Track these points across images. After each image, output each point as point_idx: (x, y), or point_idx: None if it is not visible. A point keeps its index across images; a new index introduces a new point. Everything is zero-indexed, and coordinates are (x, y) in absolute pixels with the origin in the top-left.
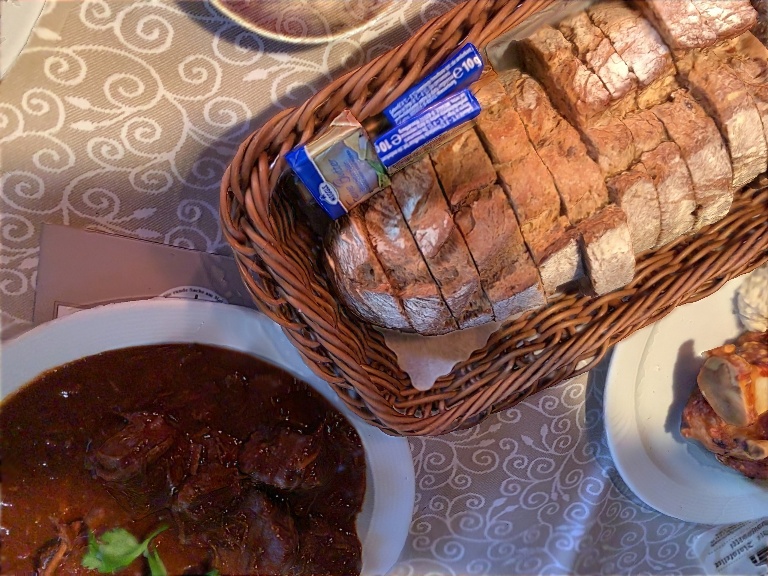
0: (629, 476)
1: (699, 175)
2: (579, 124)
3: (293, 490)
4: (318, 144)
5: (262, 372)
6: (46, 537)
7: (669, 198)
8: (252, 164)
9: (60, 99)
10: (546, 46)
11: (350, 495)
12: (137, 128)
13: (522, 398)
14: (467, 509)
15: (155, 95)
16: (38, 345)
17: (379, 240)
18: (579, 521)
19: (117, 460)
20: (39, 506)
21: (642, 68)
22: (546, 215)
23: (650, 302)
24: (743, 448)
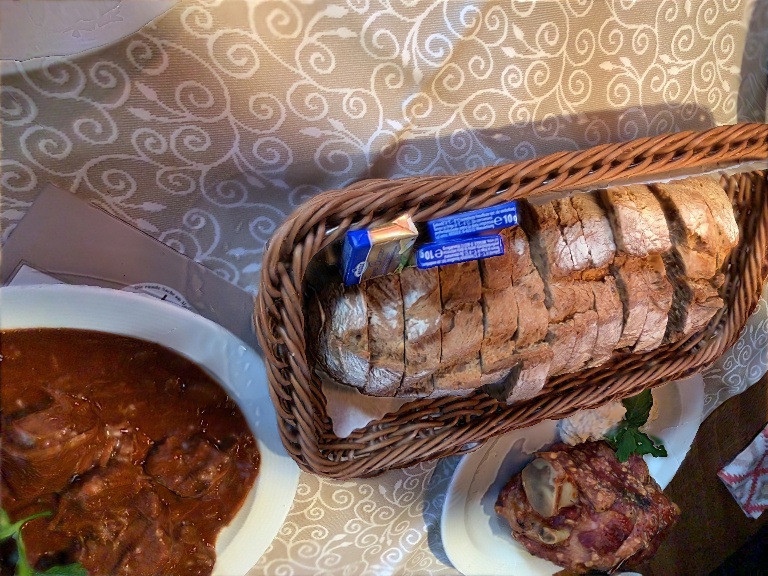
0: (447, 535)
1: (601, 339)
2: (547, 279)
3: (178, 496)
4: (380, 234)
5: (202, 384)
6: None
7: (579, 349)
8: (312, 225)
9: (130, 81)
10: (542, 211)
11: (226, 510)
12: (190, 135)
13: (415, 463)
14: (310, 538)
15: (220, 113)
16: (2, 304)
17: (375, 314)
18: (391, 564)
19: (38, 439)
20: None
21: (597, 254)
22: (502, 336)
23: (529, 413)
24: (539, 532)
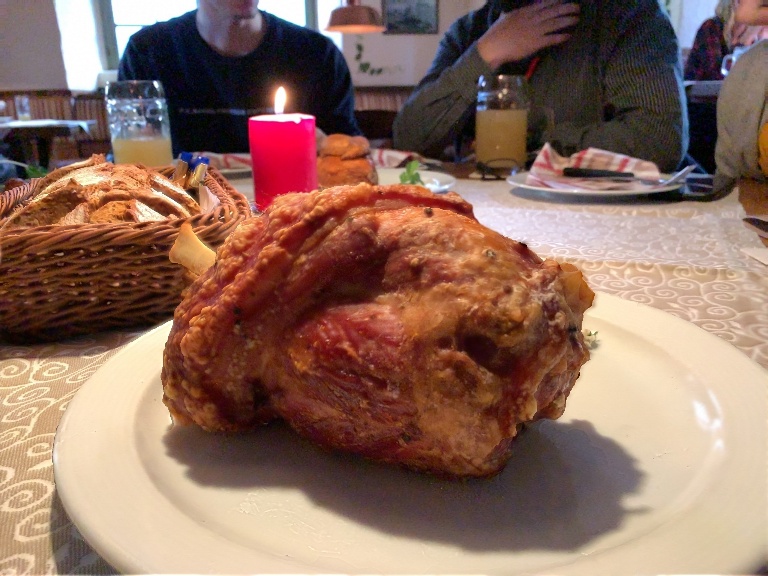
0: None
1: None
2: None
3: None
4: None
5: None
6: None
7: None
8: None
9: None
10: None
11: None
12: None
13: None
14: None
15: None
16: None
17: None
18: None
19: None
20: None
21: None
22: None
23: (5, 200)
24: None
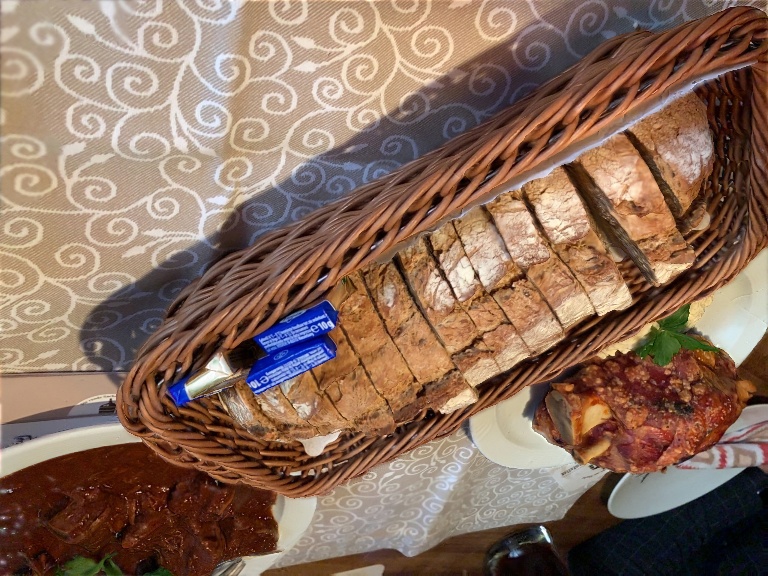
0: (490, 455)
1: (532, 341)
2: (430, 321)
3: None
4: (196, 385)
5: None
6: (19, 566)
7: (506, 358)
8: (141, 385)
9: None
10: None
11: (265, 499)
12: (26, 308)
13: (394, 457)
14: (363, 480)
15: (37, 282)
16: None
17: (263, 402)
18: (453, 473)
19: (66, 533)
20: (7, 548)
21: (486, 274)
22: (402, 383)
23: (497, 394)
24: (571, 453)
